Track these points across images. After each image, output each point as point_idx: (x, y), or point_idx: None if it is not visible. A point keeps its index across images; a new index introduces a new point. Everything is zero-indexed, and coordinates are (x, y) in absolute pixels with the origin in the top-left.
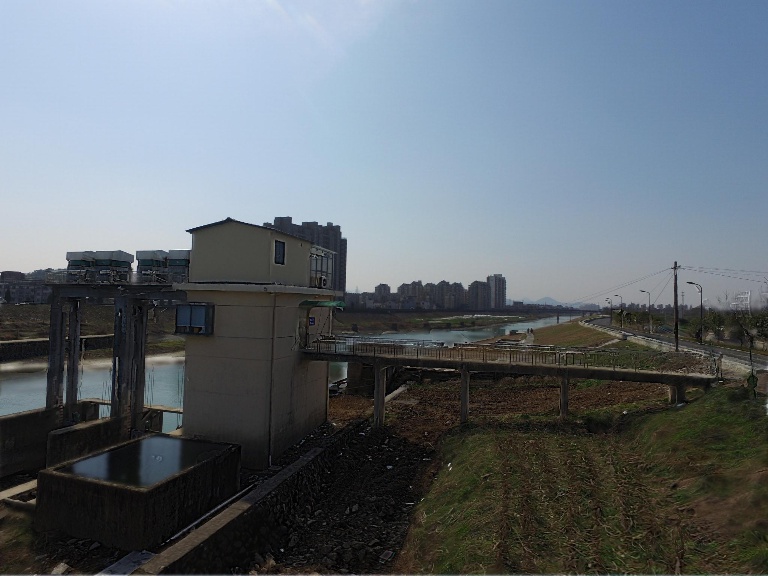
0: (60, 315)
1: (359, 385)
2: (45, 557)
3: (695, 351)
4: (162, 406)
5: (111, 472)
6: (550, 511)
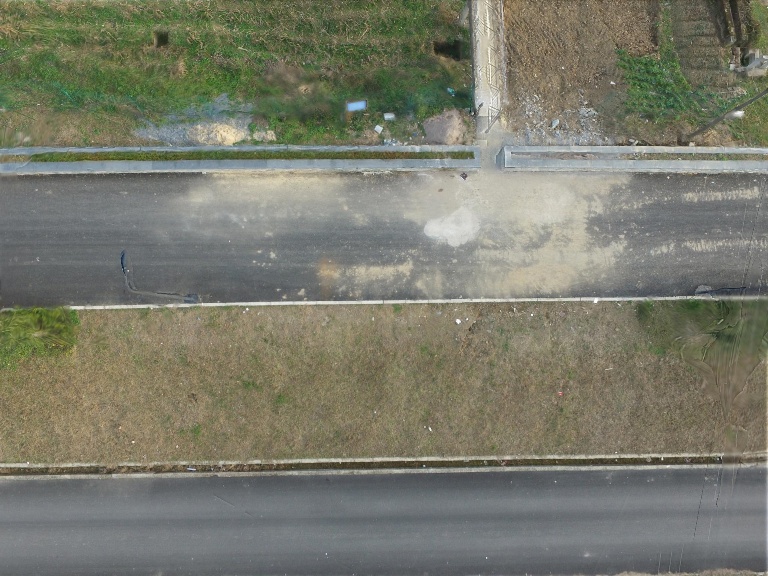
0: None
1: None
2: None
3: (678, 149)
4: None
5: None
6: (277, 7)
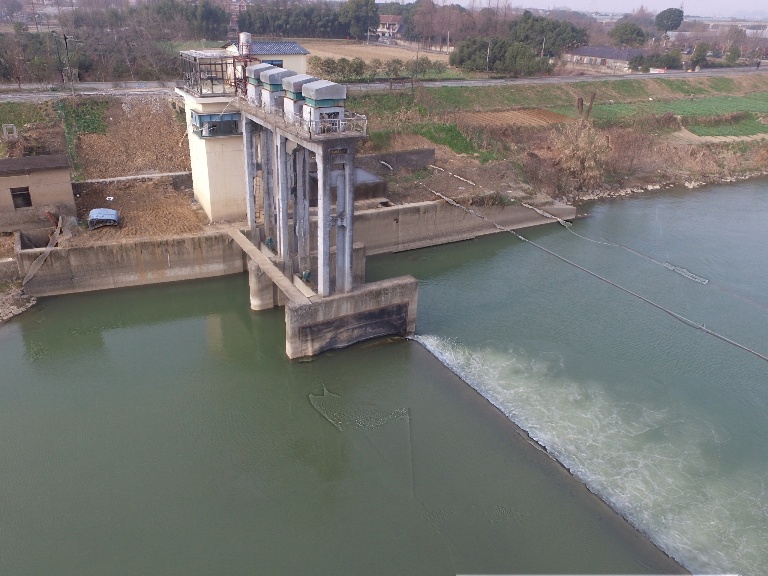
0: None
1: None
2: None
3: None
4: (255, 256)
5: None
6: None
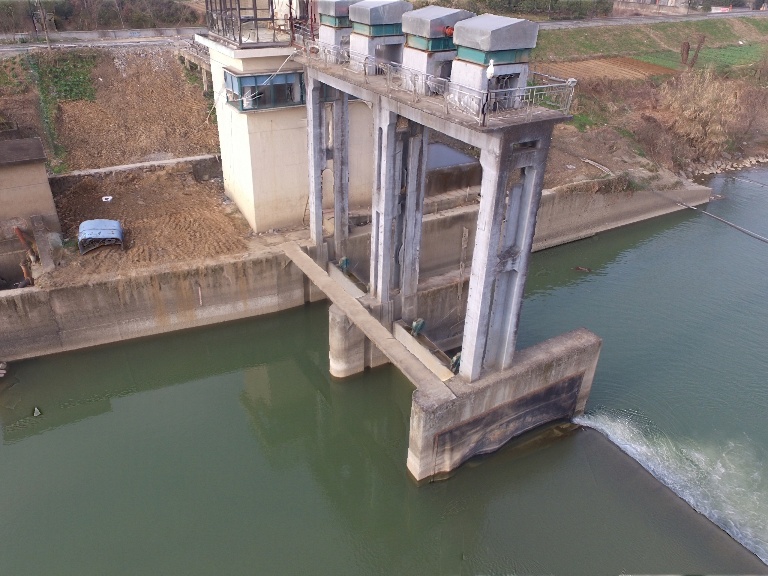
0: (522, 188)
1: None
2: None
3: None
4: (336, 297)
5: None
6: None
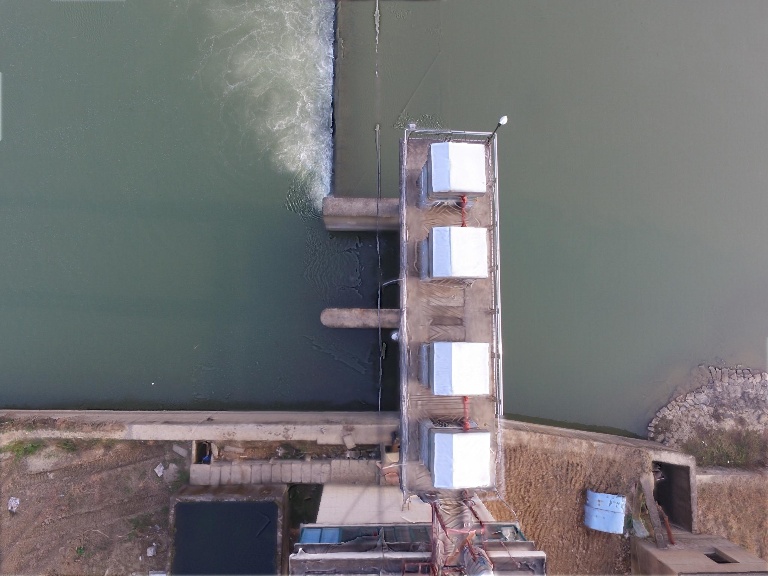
0: None
1: (641, 567)
2: (157, 530)
3: None
4: None
5: (216, 516)
6: None
